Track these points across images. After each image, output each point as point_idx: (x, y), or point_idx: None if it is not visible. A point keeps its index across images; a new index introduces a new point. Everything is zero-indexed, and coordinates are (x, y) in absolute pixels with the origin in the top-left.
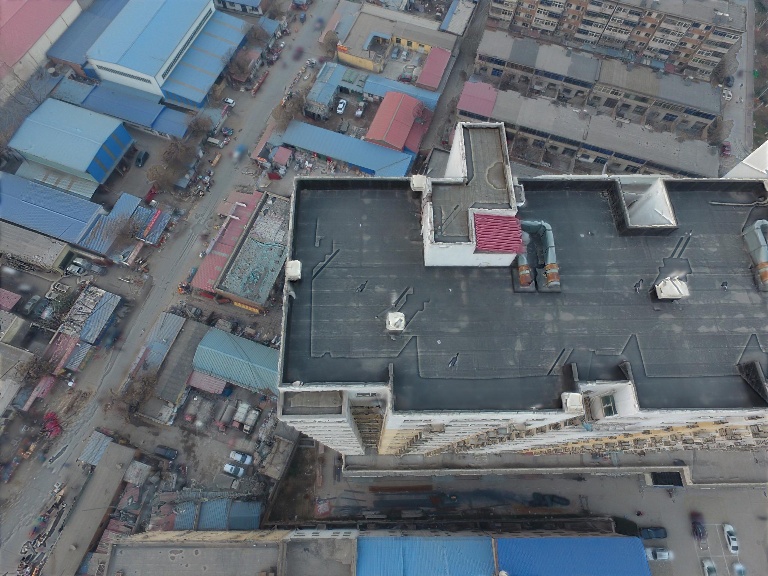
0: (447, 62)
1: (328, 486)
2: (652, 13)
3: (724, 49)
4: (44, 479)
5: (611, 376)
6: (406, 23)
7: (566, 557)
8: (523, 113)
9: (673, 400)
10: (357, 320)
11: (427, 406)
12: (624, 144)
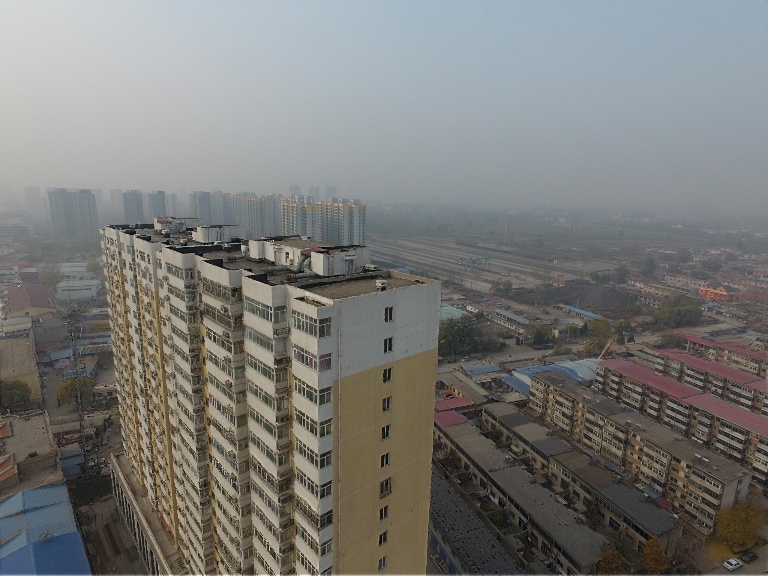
0: (464, 405)
1: (103, 505)
2: (636, 435)
3: (712, 498)
4: None
5: None
6: (468, 385)
7: (71, 570)
8: (466, 438)
9: None
10: None
11: None
12: (519, 492)
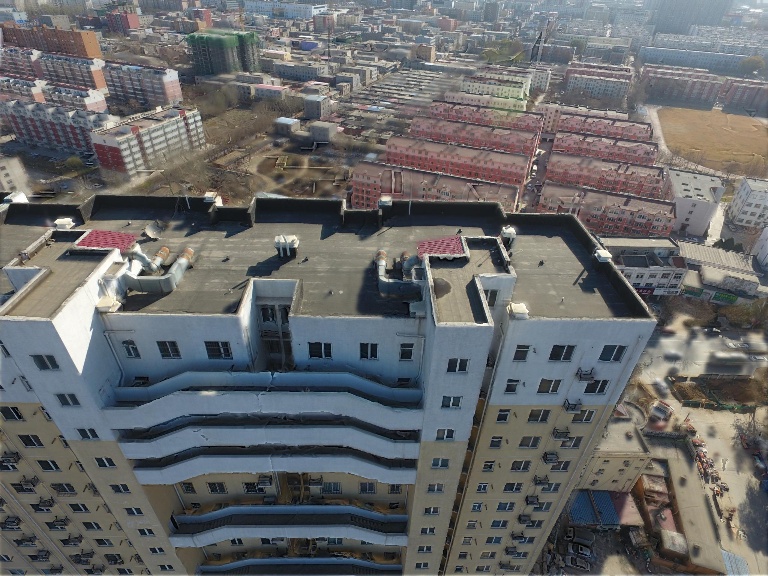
0: None
1: None
2: None
3: None
4: (763, 545)
5: (348, 226)
6: None
7: None
8: None
9: (310, 216)
10: (536, 250)
11: (474, 218)
12: None
